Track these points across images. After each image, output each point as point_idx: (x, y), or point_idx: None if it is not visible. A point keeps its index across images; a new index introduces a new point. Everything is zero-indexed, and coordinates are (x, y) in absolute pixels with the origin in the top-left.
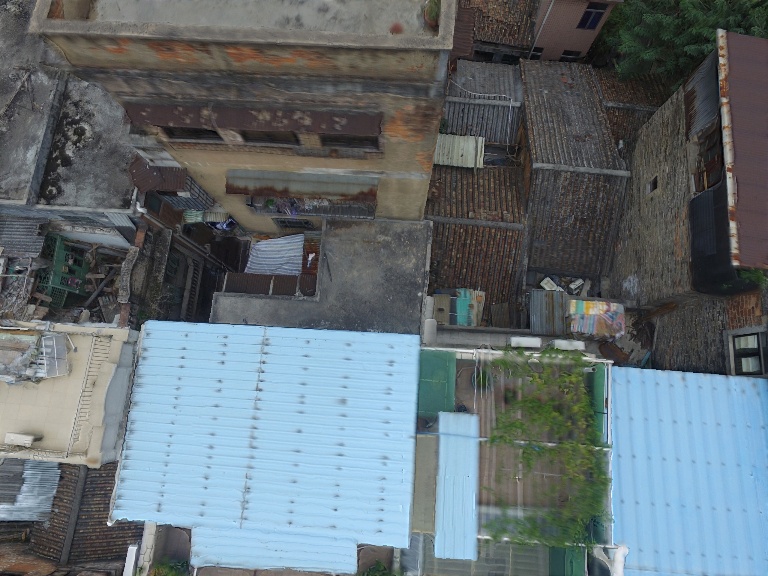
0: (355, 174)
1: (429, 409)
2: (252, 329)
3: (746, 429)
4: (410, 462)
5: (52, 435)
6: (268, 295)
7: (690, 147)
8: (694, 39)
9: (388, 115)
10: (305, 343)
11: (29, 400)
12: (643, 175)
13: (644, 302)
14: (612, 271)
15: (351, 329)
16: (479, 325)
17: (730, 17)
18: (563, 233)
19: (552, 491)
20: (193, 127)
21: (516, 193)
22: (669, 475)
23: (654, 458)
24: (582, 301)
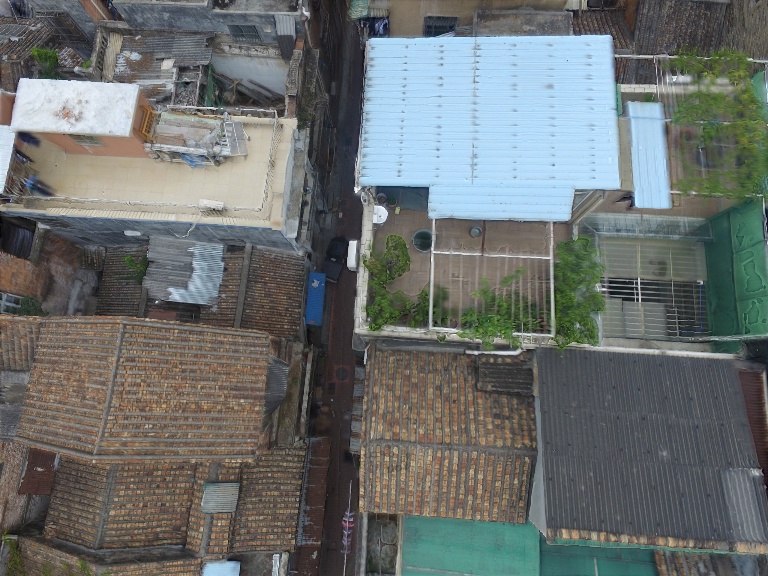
0: None
1: None
2: (464, 39)
3: None
4: (615, 126)
5: None
6: None
7: None
8: None
9: None
10: (512, 46)
11: (211, 180)
12: None
13: None
14: None
15: None
16: None
17: None
18: None
19: (731, 156)
20: None
21: (620, 30)
22: None
23: None
24: None
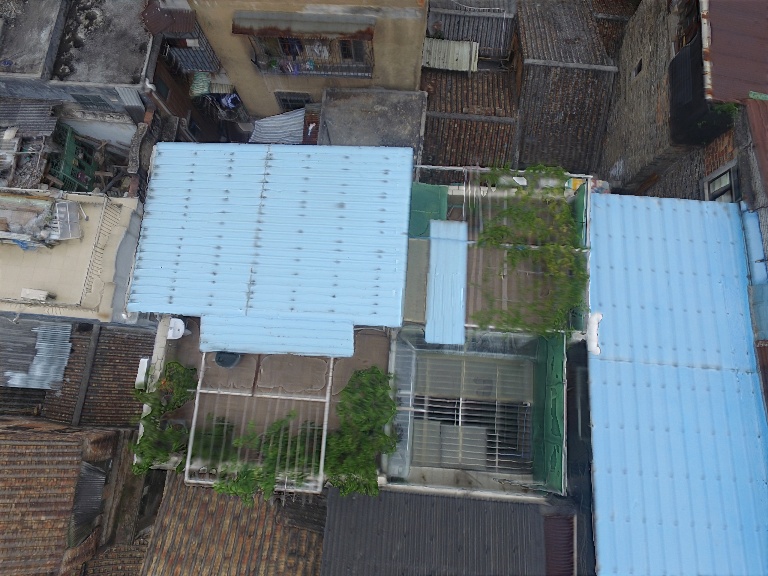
0: (353, 13)
1: None
2: (257, 146)
3: (716, 244)
4: (403, 254)
5: (65, 295)
6: None
7: (671, 17)
8: None
9: None
10: (306, 157)
11: (43, 263)
12: (629, 64)
13: (628, 179)
14: (600, 166)
15: None
16: None
17: None
18: (553, 129)
19: (534, 286)
20: None
21: (508, 93)
22: (644, 283)
23: (630, 268)
24: None
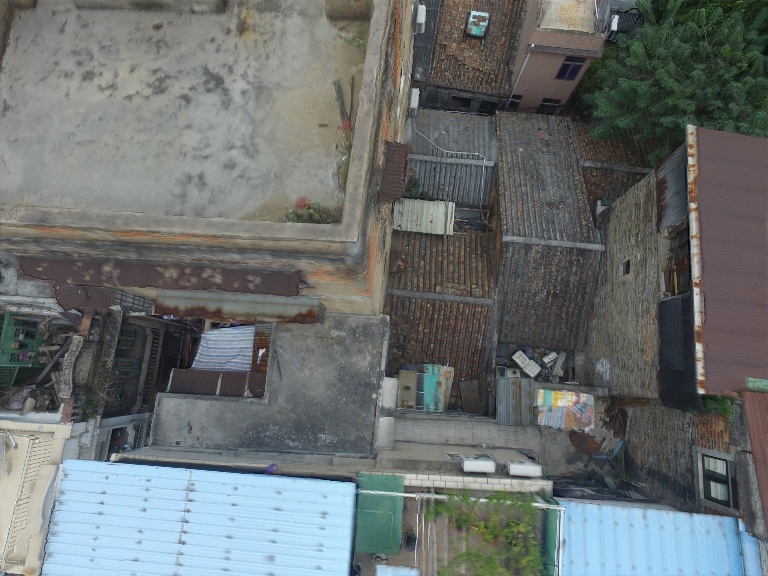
0: None
1: (373, 544)
2: (177, 472)
3: None
4: None
5: None
6: (214, 397)
7: (661, 241)
8: (671, 110)
9: (308, 271)
10: (233, 490)
11: None
12: (616, 254)
13: (615, 393)
14: (586, 346)
15: (301, 434)
16: (447, 402)
17: (708, 90)
18: (535, 307)
19: None
20: (93, 285)
21: (487, 263)
22: None
23: None
24: (550, 391)
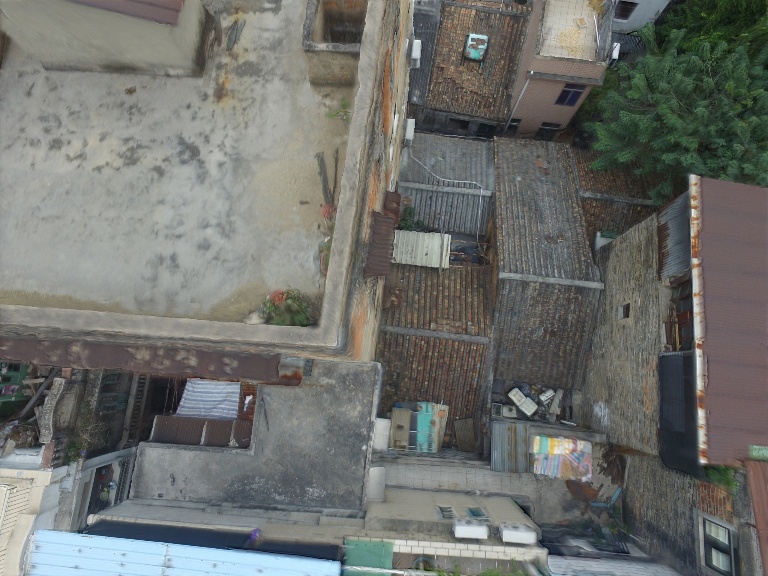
0: None
1: None
2: (153, 546)
3: None
4: None
5: None
6: (198, 447)
7: (662, 290)
8: (673, 147)
9: None
10: (211, 567)
11: None
12: (616, 295)
13: (614, 441)
14: (584, 385)
15: (288, 487)
16: (441, 441)
17: (711, 127)
18: (532, 345)
19: None
20: (60, 365)
21: (483, 298)
22: None
23: None
24: (547, 438)
